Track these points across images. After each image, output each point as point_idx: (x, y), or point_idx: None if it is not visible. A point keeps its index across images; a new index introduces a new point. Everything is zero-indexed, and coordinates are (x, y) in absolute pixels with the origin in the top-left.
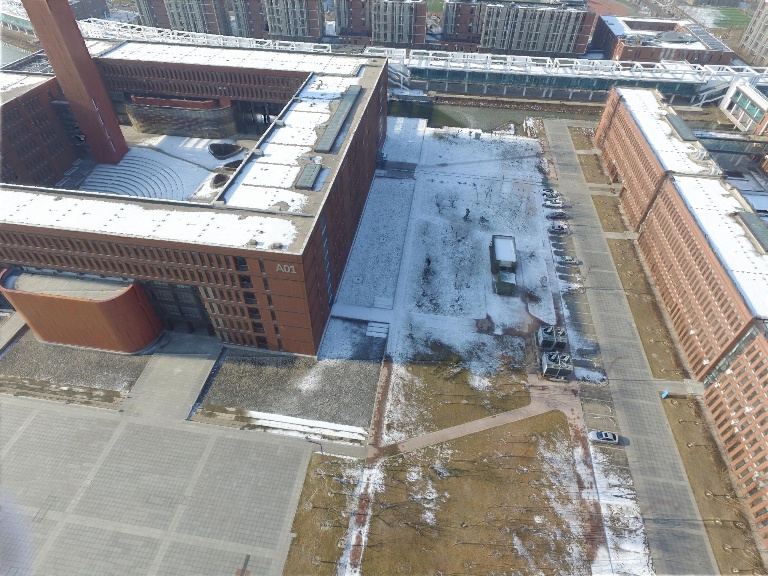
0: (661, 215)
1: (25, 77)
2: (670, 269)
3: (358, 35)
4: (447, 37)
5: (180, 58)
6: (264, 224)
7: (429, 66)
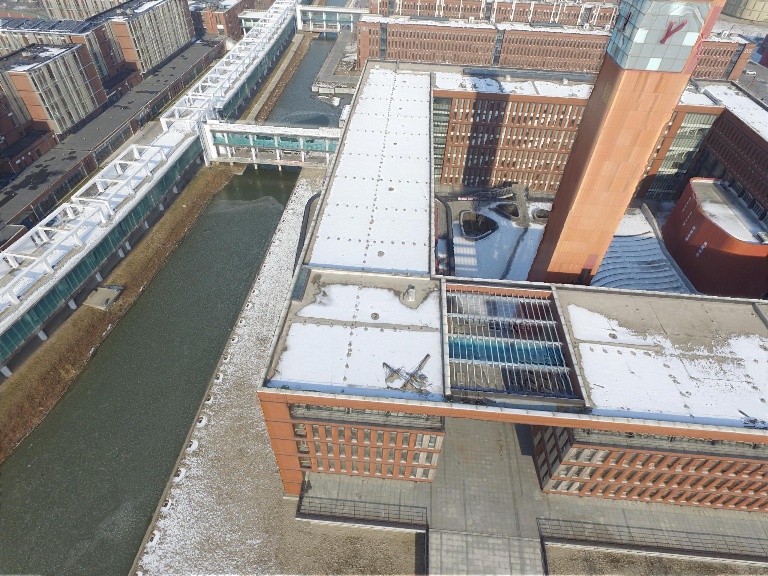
0: (514, 49)
1: (586, 344)
2: (545, 64)
3: (24, 143)
4: (102, 82)
5: (398, 182)
6: (717, 93)
7: (226, 95)
